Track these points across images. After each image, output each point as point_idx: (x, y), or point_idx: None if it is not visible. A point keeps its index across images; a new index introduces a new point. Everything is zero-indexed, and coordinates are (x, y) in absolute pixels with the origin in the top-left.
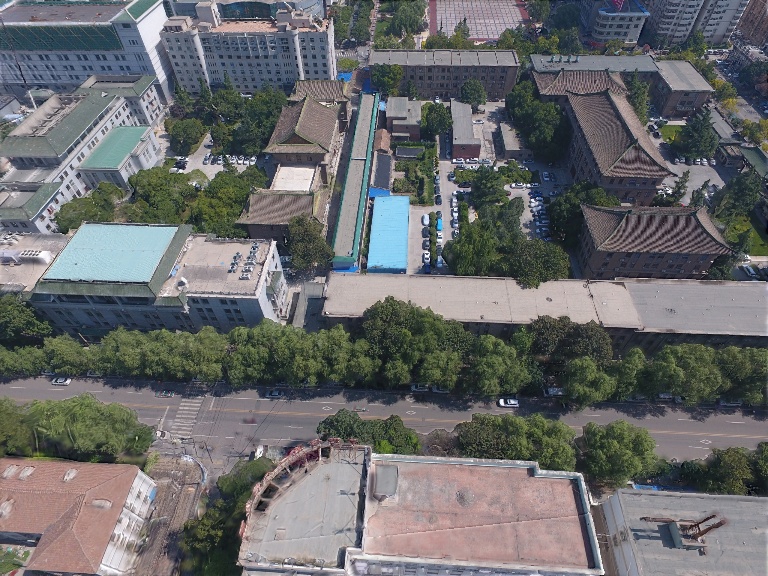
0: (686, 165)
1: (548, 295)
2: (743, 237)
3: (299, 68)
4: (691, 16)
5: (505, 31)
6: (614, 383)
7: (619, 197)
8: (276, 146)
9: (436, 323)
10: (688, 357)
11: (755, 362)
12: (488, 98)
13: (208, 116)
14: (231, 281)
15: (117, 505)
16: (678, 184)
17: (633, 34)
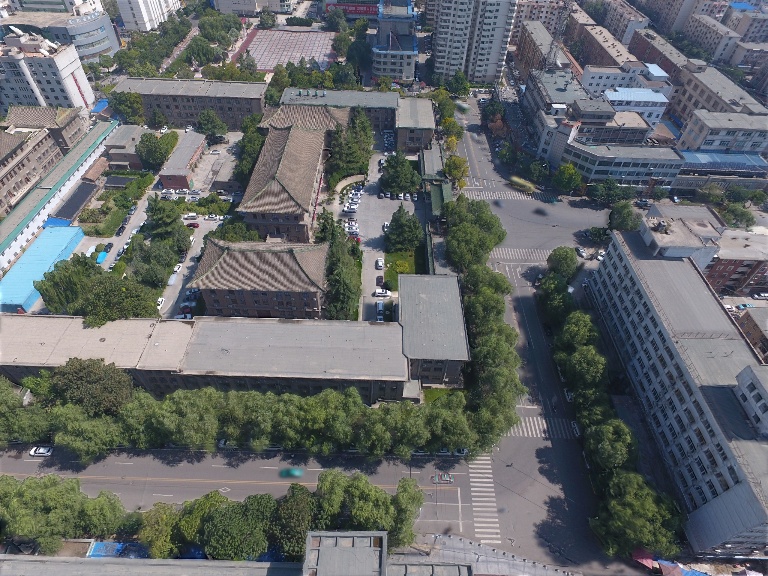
0: (390, 200)
1: (105, 335)
2: None
3: (35, 93)
4: (459, 57)
5: (278, 64)
6: (114, 430)
7: (271, 232)
8: None
9: None
10: (181, 402)
11: (249, 407)
12: None
13: None
14: None
15: None
16: None
17: (408, 71)
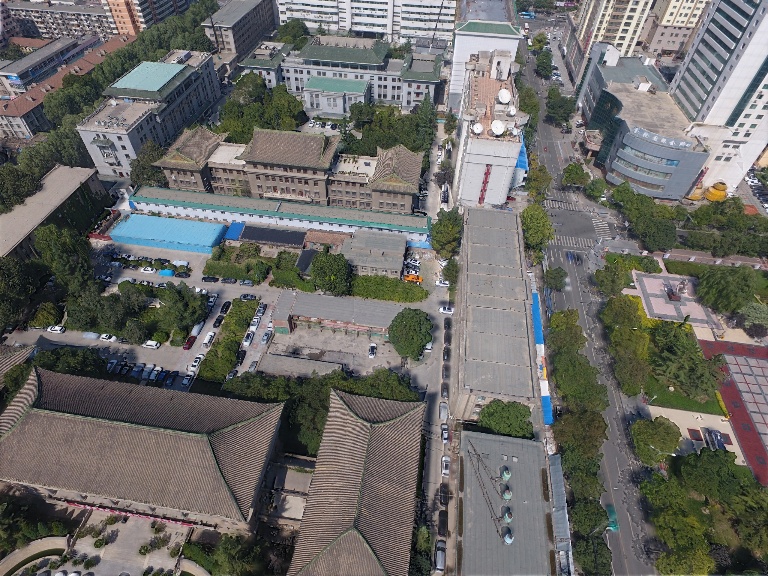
0: None
1: None
2: None
3: (459, 155)
4: None
5: None
6: None
7: None
8: None
9: None
10: None
11: None
12: None
13: None
14: (102, 119)
15: (4, 112)
16: None
17: None
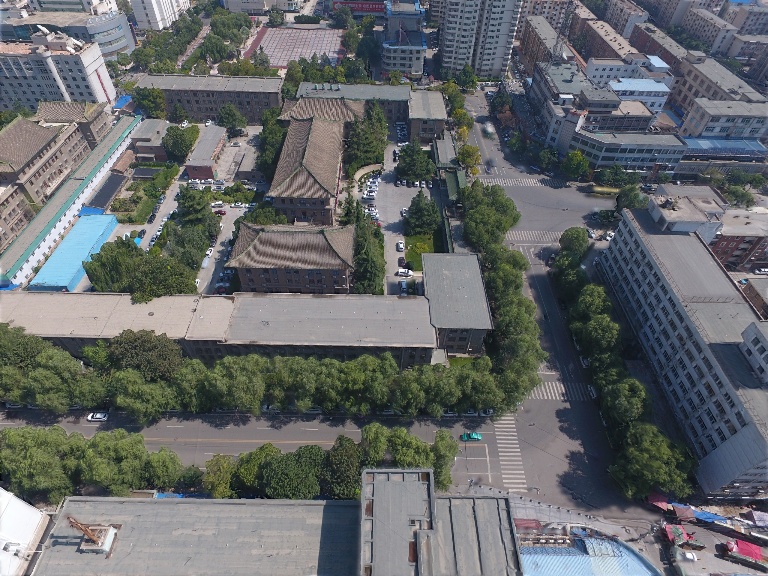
0: (406, 187)
1: (153, 310)
2: None
3: (61, 89)
4: (467, 51)
5: (292, 60)
6: (169, 394)
7: (298, 216)
8: None
9: None
10: (231, 367)
11: (294, 370)
12: (259, 122)
13: None
14: None
15: None
16: None
17: (417, 66)
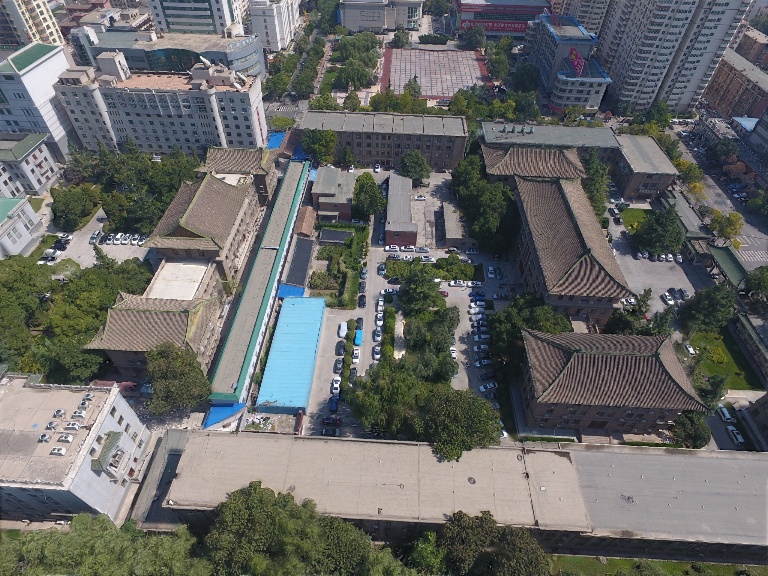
0: (650, 261)
1: (471, 473)
2: (716, 386)
3: (218, 130)
4: (654, 84)
5: (457, 92)
6: None
7: (570, 313)
8: (159, 239)
9: (303, 545)
10: None
11: None
12: (435, 168)
13: (108, 182)
14: (38, 458)
15: None
16: (639, 302)
17: (594, 100)
